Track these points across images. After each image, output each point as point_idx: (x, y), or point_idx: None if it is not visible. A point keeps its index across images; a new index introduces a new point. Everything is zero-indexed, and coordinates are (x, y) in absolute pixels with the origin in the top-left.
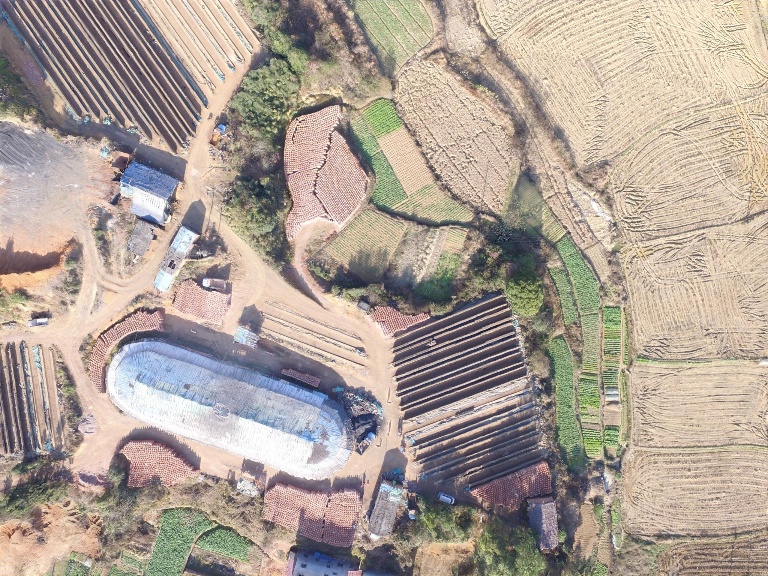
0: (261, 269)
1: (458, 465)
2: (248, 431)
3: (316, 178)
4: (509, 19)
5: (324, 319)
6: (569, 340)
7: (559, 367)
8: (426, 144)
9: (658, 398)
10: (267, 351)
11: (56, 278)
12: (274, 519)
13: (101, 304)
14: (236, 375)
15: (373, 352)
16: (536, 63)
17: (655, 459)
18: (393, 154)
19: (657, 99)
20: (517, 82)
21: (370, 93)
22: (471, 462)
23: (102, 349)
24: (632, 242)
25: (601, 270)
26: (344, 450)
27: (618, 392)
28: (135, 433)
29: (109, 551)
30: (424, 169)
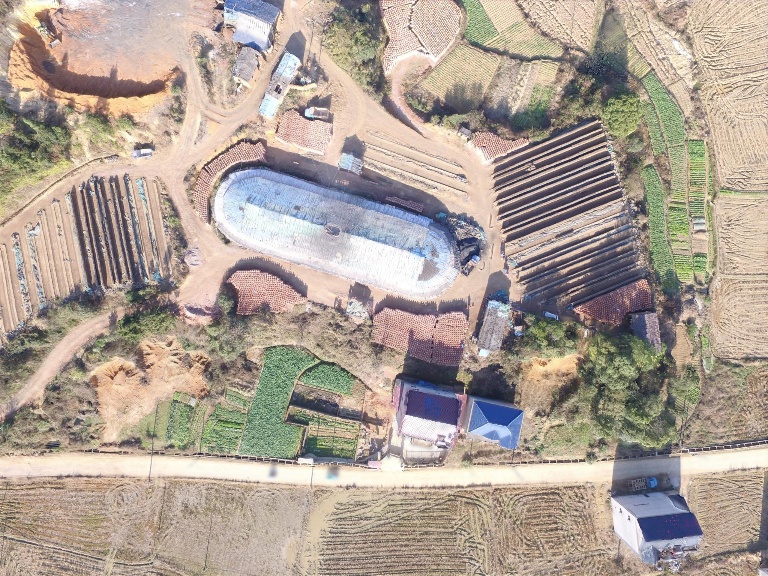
0: (362, 100)
1: (561, 284)
2: (359, 250)
3: (411, 13)
4: None
5: (425, 148)
6: (659, 169)
7: (650, 194)
8: None
9: (741, 228)
10: (369, 181)
11: (162, 104)
12: (384, 341)
13: (205, 134)
14: (343, 199)
15: (474, 179)
16: None
17: (740, 286)
18: None
19: None
20: None
21: None
22: (572, 282)
23: (207, 180)
24: (712, 80)
25: (685, 105)
26: (452, 269)
27: (705, 221)
28: (241, 264)
29: (216, 385)
30: (514, 7)
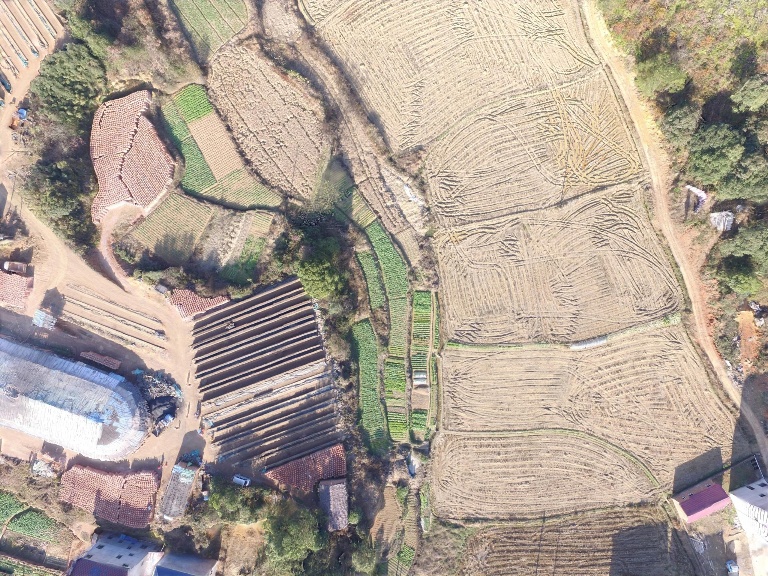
0: (63, 252)
1: (254, 447)
2: (39, 412)
3: (122, 162)
4: (328, 5)
5: (125, 302)
6: (374, 324)
7: (363, 350)
8: (237, 129)
9: (469, 382)
10: (69, 334)
11: None
12: (70, 500)
13: None
14: (32, 357)
15: (173, 335)
16: (354, 49)
17: (465, 443)
18: (203, 139)
19: (473, 84)
20: (331, 68)
21: (180, 78)
22: (268, 444)
23: None
24: (445, 227)
25: (412, 254)
26: (136, 431)
27: (426, 376)
28: None
29: None
30: (234, 154)
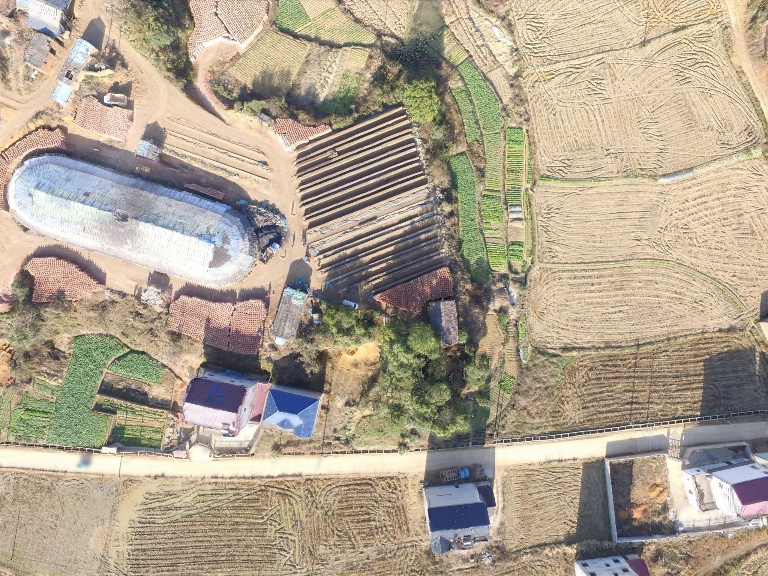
0: (163, 86)
1: (361, 272)
2: (149, 237)
3: None
4: None
5: (227, 134)
6: (471, 156)
7: (462, 182)
8: None
9: (561, 216)
10: (171, 168)
11: None
12: (180, 329)
13: (1, 121)
14: (138, 186)
15: (276, 166)
16: None
17: (560, 275)
18: None
19: None
20: None
21: None
22: (375, 270)
23: (3, 166)
24: (534, 67)
25: (503, 92)
26: (246, 256)
27: (521, 209)
28: (40, 251)
29: (18, 374)
30: None
